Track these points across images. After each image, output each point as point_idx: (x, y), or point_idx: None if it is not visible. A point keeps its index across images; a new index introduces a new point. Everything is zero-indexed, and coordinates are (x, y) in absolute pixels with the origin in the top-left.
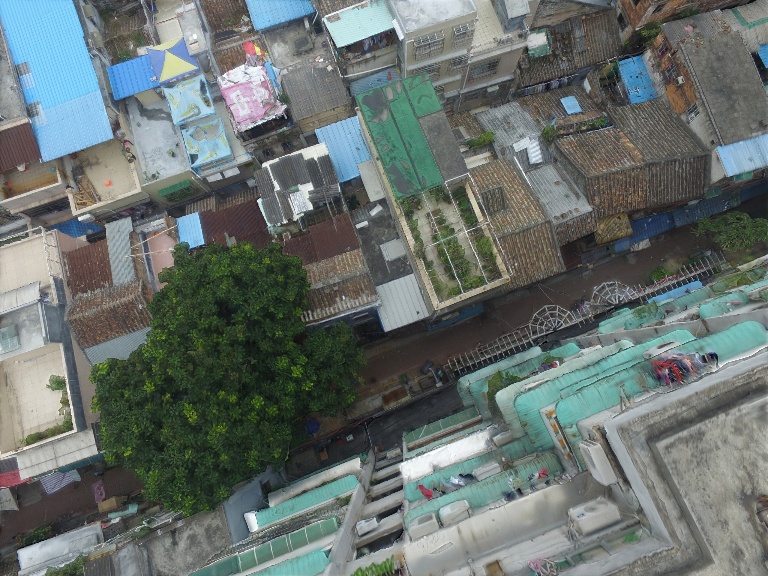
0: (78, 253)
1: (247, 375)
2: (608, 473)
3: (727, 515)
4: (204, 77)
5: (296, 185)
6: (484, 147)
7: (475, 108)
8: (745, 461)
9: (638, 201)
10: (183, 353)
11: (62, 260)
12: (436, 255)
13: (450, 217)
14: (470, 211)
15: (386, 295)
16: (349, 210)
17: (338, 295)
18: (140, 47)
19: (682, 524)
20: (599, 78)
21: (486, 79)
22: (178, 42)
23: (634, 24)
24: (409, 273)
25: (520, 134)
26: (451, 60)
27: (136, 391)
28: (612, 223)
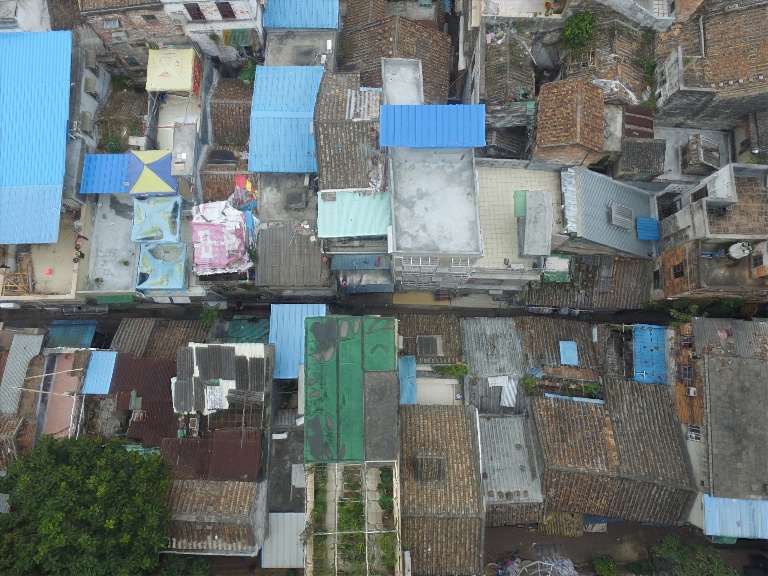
0: None
1: None
2: None
3: None
4: (181, 199)
5: (218, 378)
6: None
7: (476, 293)
8: None
9: (598, 508)
10: None
11: None
12: None
13: (369, 481)
14: None
15: (277, 526)
16: (282, 397)
17: (211, 533)
18: (133, 136)
19: None
20: (612, 329)
21: None
22: (164, 156)
23: (667, 293)
24: None
25: (501, 367)
26: (447, 274)
27: None
28: (562, 518)
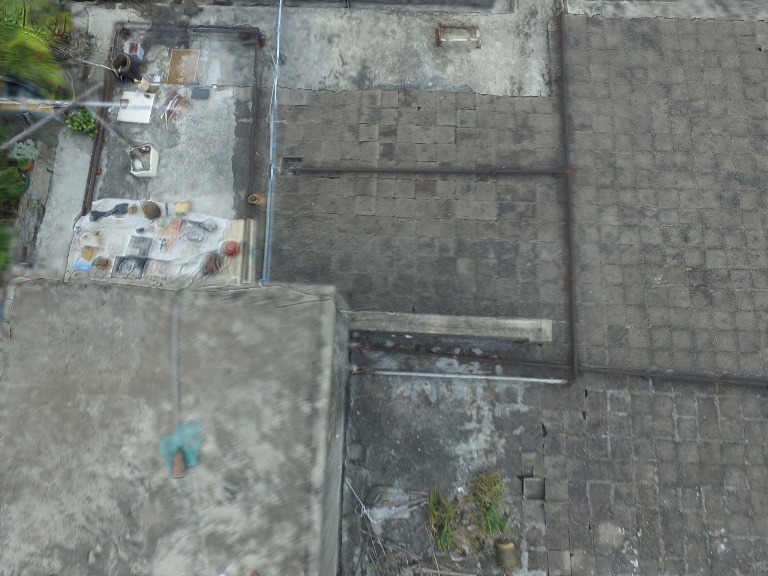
0: None
1: None
2: None
3: None
4: None
5: None
6: None
7: None
8: None
9: None
10: None
11: None
12: None
13: None
14: None
15: None
16: None
17: None
18: None
19: (507, 2)
20: None
21: None
22: None
23: None
24: None
25: None
26: None
27: None
28: None
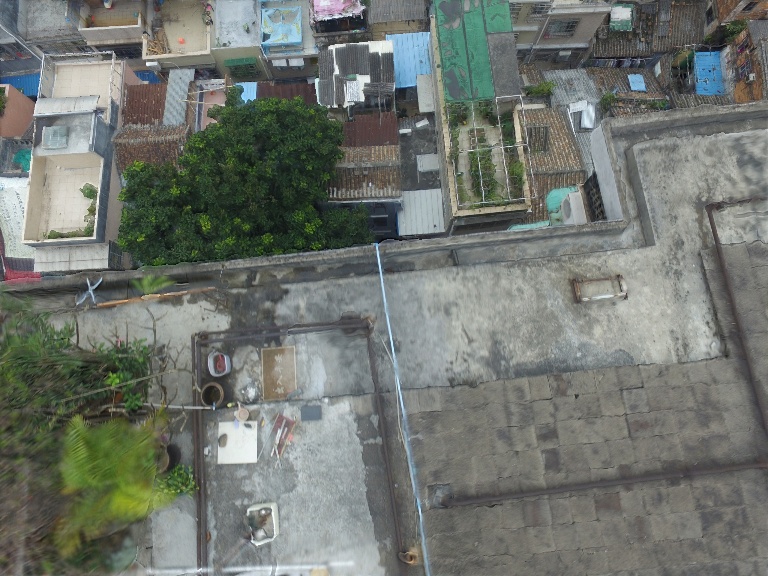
0: (139, 88)
1: (264, 217)
2: (581, 217)
3: (678, 211)
4: None
5: (355, 74)
6: (541, 98)
7: None
8: (708, 175)
9: None
10: (214, 165)
11: (123, 90)
12: (468, 170)
13: (491, 139)
14: (511, 138)
15: (410, 202)
16: None
17: (366, 180)
18: None
19: (636, 222)
20: (672, 66)
21: (561, 40)
22: None
23: (721, 18)
24: (437, 187)
25: (579, 97)
26: (533, 4)
27: (162, 192)
28: None
